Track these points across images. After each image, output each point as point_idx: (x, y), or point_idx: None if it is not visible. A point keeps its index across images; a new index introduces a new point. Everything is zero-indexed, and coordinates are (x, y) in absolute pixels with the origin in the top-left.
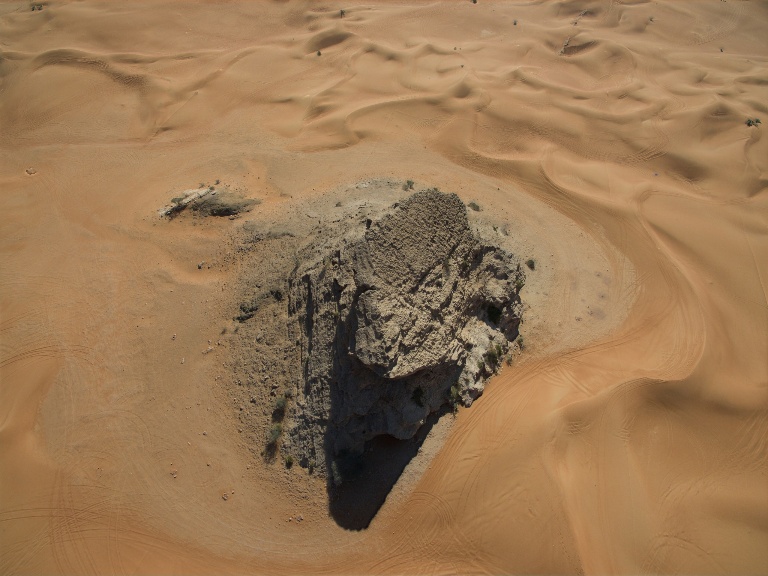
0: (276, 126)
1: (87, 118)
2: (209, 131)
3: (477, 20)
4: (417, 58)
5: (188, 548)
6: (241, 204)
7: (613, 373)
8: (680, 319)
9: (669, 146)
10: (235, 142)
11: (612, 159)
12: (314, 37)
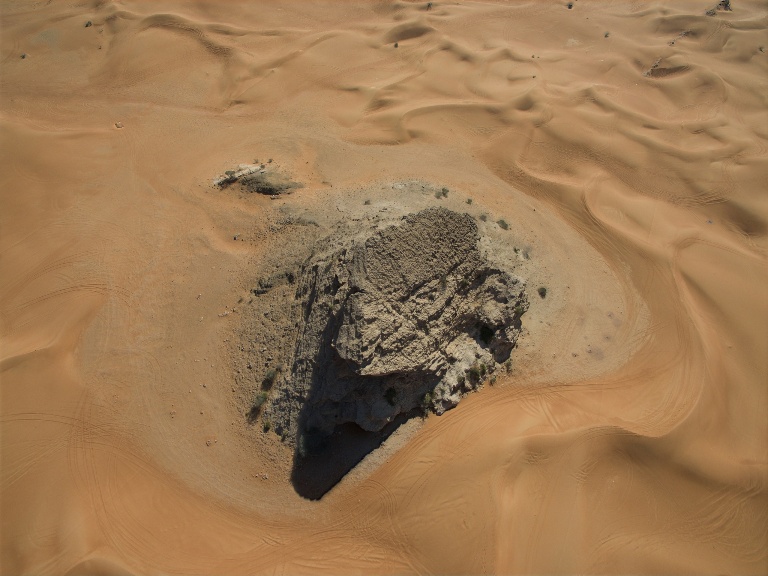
0: (337, 114)
1: (175, 82)
2: (276, 110)
3: (567, 27)
4: (490, 62)
5: (170, 478)
6: (284, 186)
7: (589, 415)
8: (679, 377)
9: (733, 193)
10: (296, 124)
11: (666, 197)
12: (395, 28)
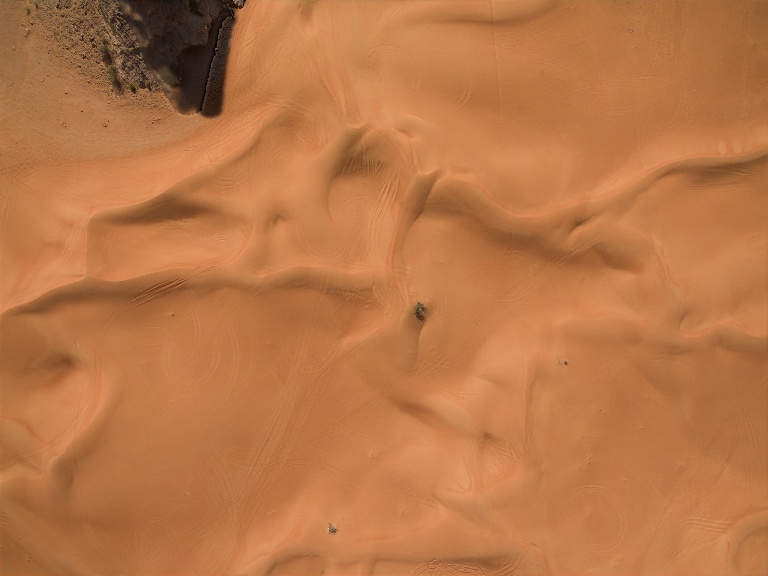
0: None
1: None
2: None
3: None
4: None
5: (100, 159)
6: None
7: None
8: None
9: None
10: None
11: None
12: None
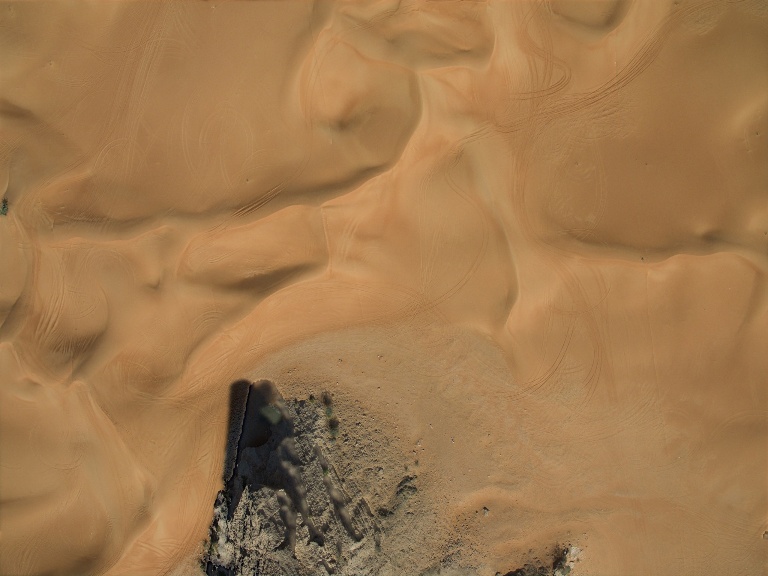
0: None
1: None
2: None
3: None
4: None
5: (343, 327)
6: None
7: (127, 569)
8: None
9: None
10: None
11: None
12: None
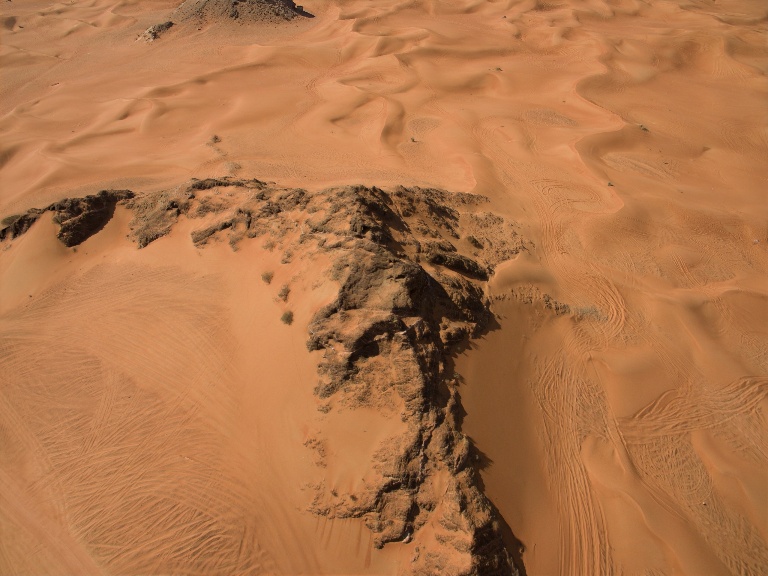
0: (96, 33)
1: (2, 79)
2: None
3: (36, 3)
4: None
5: None
6: None
7: None
8: None
9: None
10: None
11: None
12: None
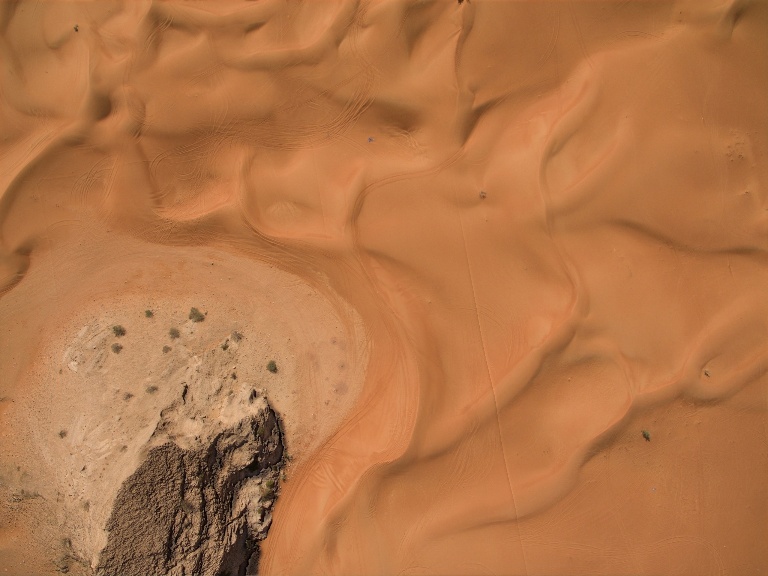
0: None
1: None
2: None
3: None
4: (5, 32)
5: None
6: None
7: (358, 461)
8: (401, 379)
9: (375, 87)
10: None
11: (319, 135)
12: None
